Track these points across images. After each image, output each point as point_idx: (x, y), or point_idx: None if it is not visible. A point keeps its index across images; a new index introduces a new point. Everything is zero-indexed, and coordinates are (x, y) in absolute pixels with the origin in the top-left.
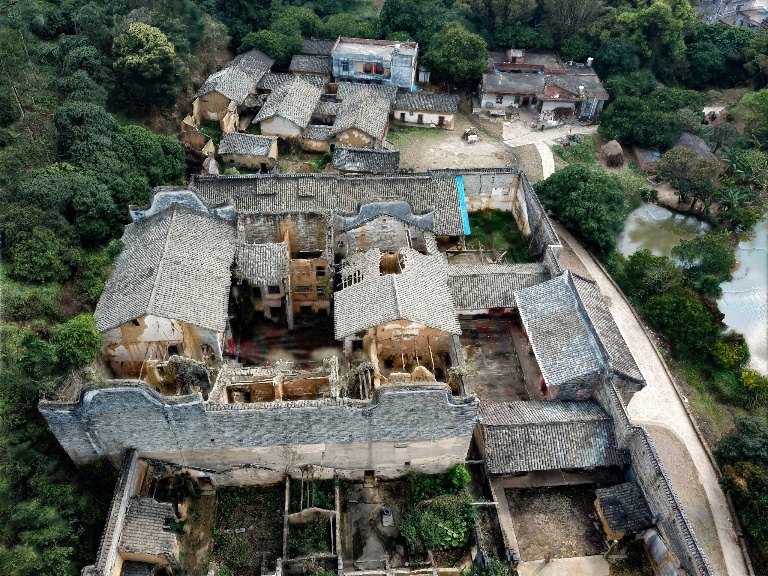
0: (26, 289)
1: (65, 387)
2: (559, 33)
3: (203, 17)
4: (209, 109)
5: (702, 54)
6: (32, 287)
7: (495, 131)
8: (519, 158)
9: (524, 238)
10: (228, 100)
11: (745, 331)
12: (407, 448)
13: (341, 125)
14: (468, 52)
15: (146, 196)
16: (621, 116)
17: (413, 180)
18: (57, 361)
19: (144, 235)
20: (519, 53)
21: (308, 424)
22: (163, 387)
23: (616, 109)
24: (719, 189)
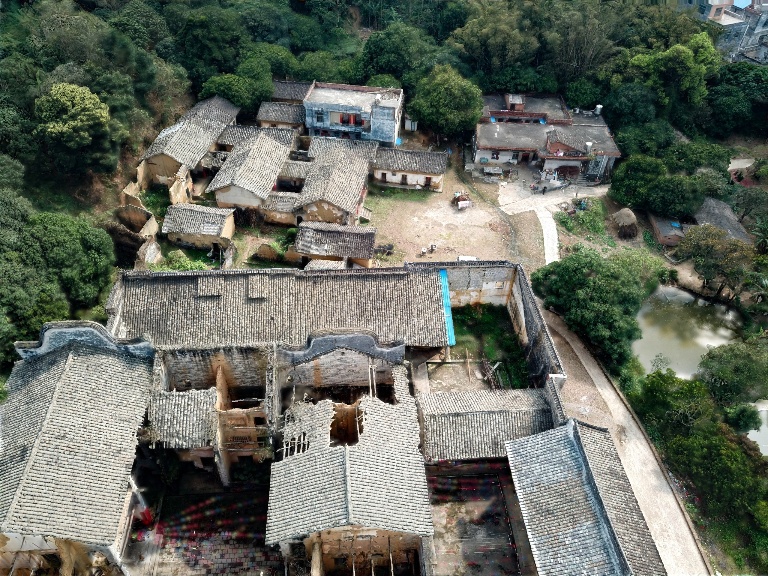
0: None
1: None
2: (564, 75)
3: (155, 62)
4: (158, 172)
5: (725, 100)
6: None
7: (490, 193)
8: (517, 230)
9: (520, 345)
10: (179, 163)
11: None
12: None
13: (309, 195)
14: (460, 102)
15: (55, 308)
16: (635, 179)
17: (387, 276)
18: None
19: (31, 384)
20: (518, 99)
21: None
22: None
23: (629, 170)
24: (751, 274)
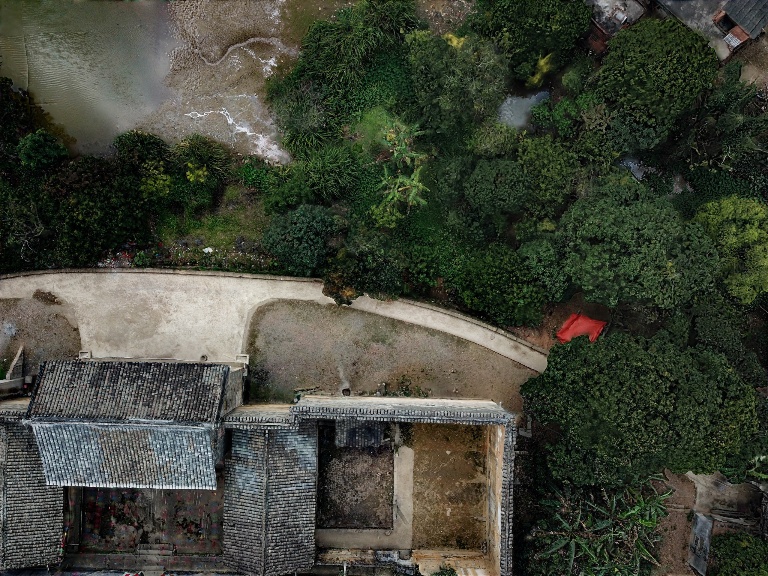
0: None
1: None
2: None
3: None
4: None
5: None
6: None
7: None
8: None
9: None
10: None
11: (103, 105)
12: None
13: None
14: None
15: None
16: None
17: None
18: None
19: None
20: None
21: None
22: None
23: None
24: None
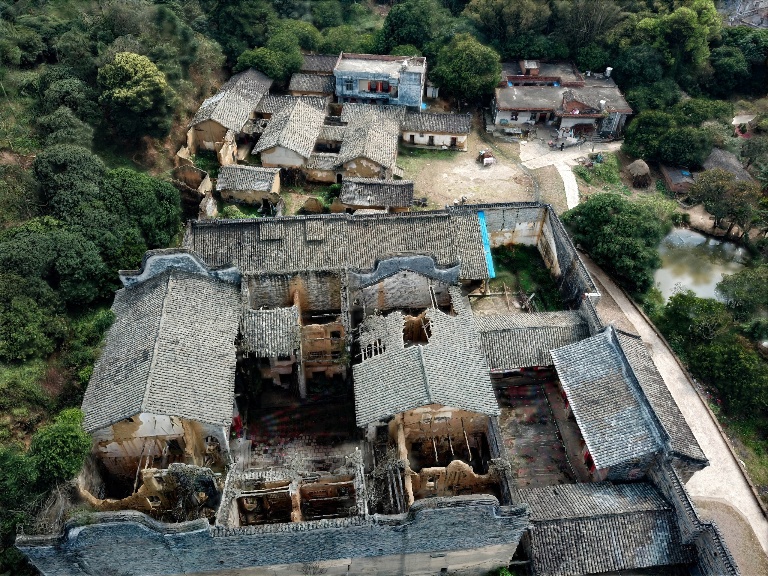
0: (5, 370)
1: (49, 506)
2: (574, 41)
3: (195, 37)
4: (205, 138)
5: (727, 60)
6: (12, 367)
7: (511, 151)
8: (539, 182)
9: (553, 278)
10: (225, 129)
11: None
12: (445, 557)
13: (348, 153)
14: (480, 67)
15: (138, 250)
16: (647, 132)
17: (430, 218)
18: (39, 475)
19: (137, 305)
20: (533, 64)
21: (332, 542)
22: (163, 495)
23: (641, 125)
24: (758, 213)
